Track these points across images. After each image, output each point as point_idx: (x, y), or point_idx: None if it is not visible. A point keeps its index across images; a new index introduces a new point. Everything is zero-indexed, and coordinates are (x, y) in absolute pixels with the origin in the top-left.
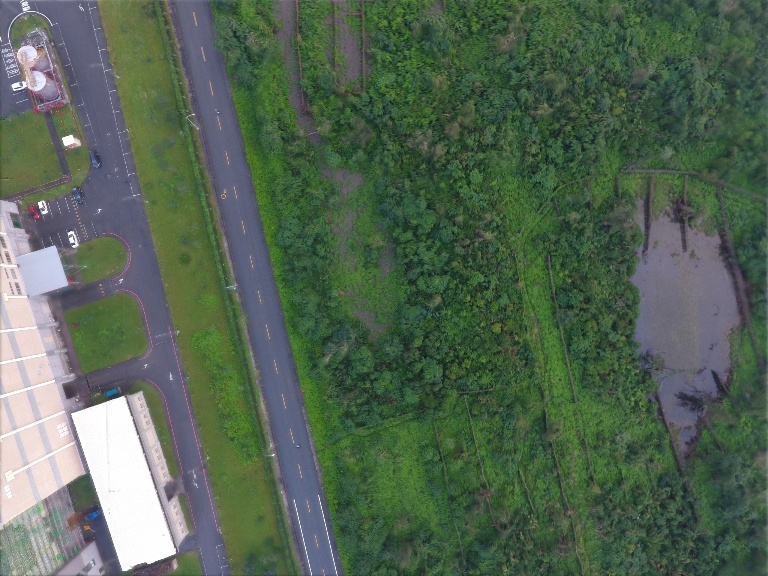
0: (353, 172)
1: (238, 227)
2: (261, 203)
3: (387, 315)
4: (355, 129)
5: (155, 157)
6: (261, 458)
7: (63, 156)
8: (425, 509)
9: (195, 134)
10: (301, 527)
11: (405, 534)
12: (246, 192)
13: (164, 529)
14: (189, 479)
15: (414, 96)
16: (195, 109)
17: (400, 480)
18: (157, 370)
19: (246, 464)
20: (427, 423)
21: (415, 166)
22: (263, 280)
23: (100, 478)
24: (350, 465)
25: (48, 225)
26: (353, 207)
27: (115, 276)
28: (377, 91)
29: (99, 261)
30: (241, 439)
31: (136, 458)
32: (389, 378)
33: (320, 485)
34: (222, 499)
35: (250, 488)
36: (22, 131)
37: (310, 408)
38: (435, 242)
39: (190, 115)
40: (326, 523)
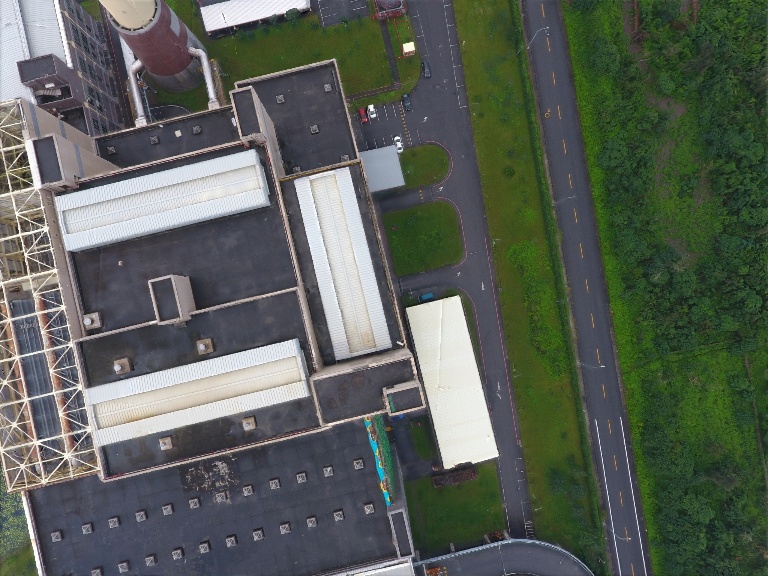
0: (678, 101)
1: (559, 146)
2: (586, 124)
3: (699, 245)
4: (686, 59)
5: (486, 71)
6: (568, 375)
7: (394, 64)
8: (729, 440)
9: (525, 53)
10: (601, 448)
11: (707, 463)
12: (570, 113)
13: (489, 430)
14: (493, 390)
15: (745, 32)
16: (526, 29)
17: (705, 409)
18: (470, 279)
19: (554, 379)
20: (741, 353)
21: (742, 100)
22: (580, 200)
23: (430, 374)
24: (660, 388)
25: (374, 129)
26: (674, 136)
27: (435, 184)
28: (709, 24)
29: (422, 168)
30: (553, 353)
31: (467, 357)
32: (709, 304)
33: (623, 407)
34: (525, 412)
35: (555, 403)
36: (358, 37)
37: (620, 329)
38: (762, 174)
39: (544, 28)
40: (626, 446)
